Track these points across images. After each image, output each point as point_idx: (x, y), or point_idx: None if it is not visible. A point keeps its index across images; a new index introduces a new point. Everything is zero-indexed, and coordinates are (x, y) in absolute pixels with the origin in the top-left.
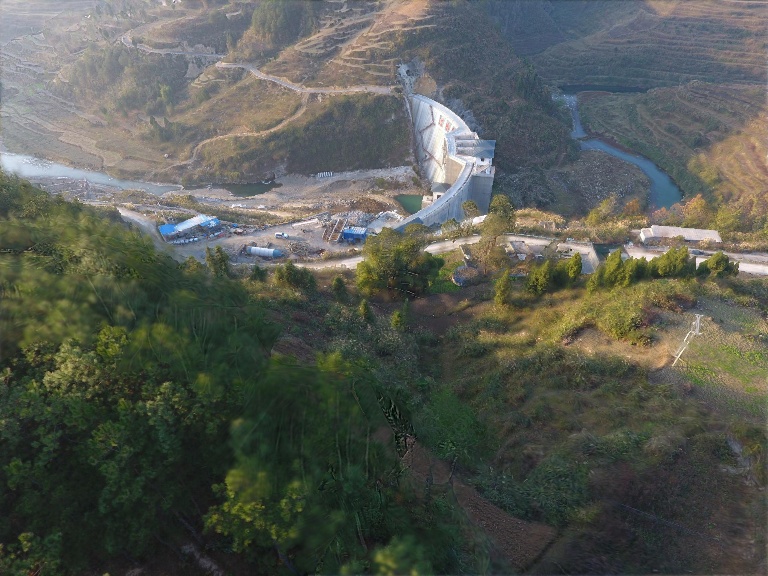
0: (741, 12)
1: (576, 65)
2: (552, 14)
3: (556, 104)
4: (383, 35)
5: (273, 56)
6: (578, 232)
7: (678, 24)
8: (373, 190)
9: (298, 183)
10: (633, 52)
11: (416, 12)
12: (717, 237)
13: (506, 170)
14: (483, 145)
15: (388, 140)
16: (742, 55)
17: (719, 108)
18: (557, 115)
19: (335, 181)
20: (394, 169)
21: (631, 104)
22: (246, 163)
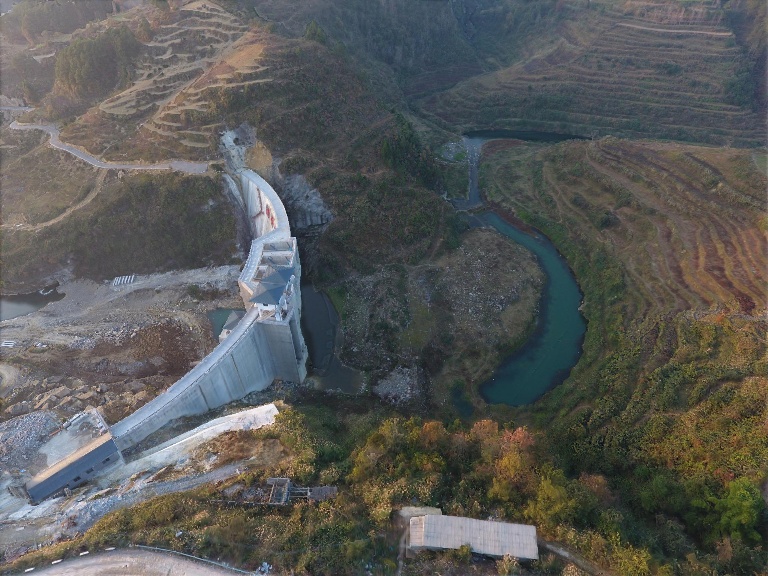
0: (670, 43)
1: (485, 106)
2: (473, 39)
3: (439, 170)
4: (203, 93)
5: (82, 114)
6: (286, 546)
7: (600, 57)
8: (184, 302)
9: (85, 293)
10: (549, 91)
11: (246, 62)
12: (531, 545)
13: (359, 270)
14: (272, 279)
15: (207, 232)
16: (671, 95)
17: (633, 175)
18: (442, 183)
19: (133, 291)
20: (216, 270)
21: (538, 161)
22: (12, 269)
